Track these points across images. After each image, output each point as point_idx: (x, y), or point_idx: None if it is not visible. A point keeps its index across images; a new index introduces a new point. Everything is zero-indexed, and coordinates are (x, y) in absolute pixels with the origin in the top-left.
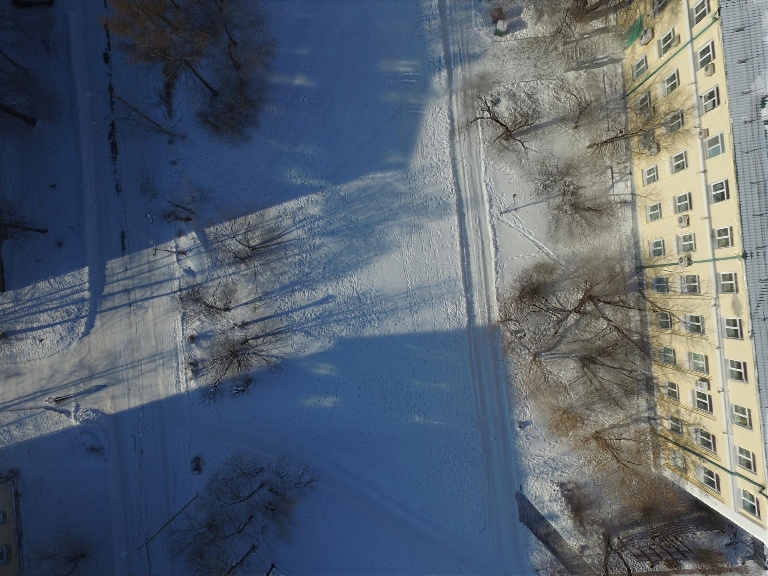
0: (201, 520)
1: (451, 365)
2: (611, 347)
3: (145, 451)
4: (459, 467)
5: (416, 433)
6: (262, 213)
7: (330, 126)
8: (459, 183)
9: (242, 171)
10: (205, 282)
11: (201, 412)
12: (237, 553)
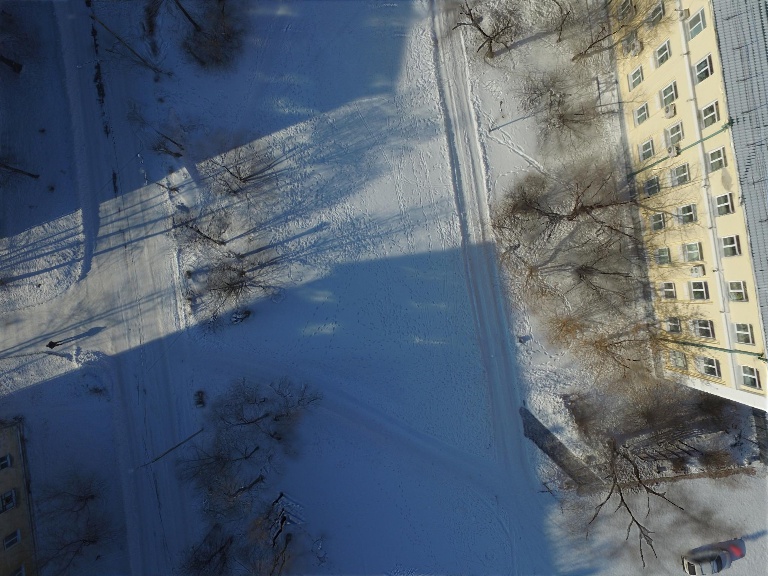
0: (207, 450)
1: (448, 285)
2: (605, 244)
3: (148, 390)
4: (462, 385)
5: (417, 354)
6: (252, 145)
7: (315, 54)
8: (446, 103)
9: (229, 104)
10: (199, 217)
11: (202, 347)
12: (245, 478)
